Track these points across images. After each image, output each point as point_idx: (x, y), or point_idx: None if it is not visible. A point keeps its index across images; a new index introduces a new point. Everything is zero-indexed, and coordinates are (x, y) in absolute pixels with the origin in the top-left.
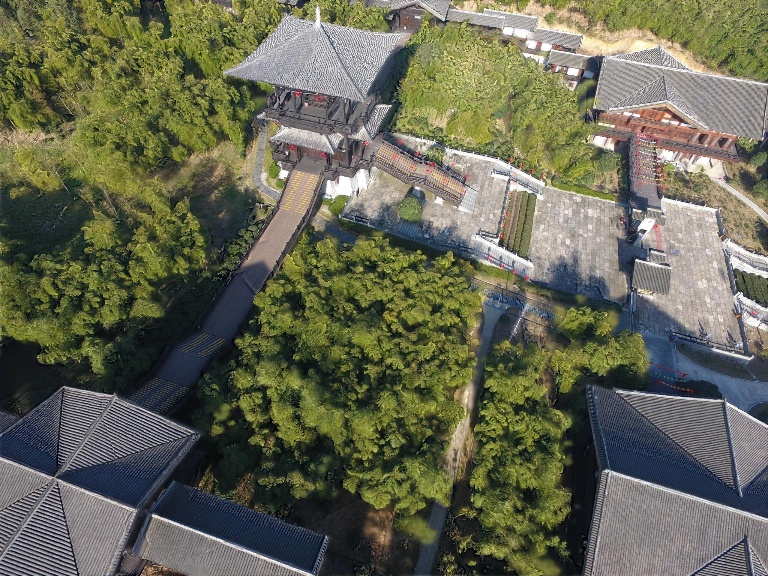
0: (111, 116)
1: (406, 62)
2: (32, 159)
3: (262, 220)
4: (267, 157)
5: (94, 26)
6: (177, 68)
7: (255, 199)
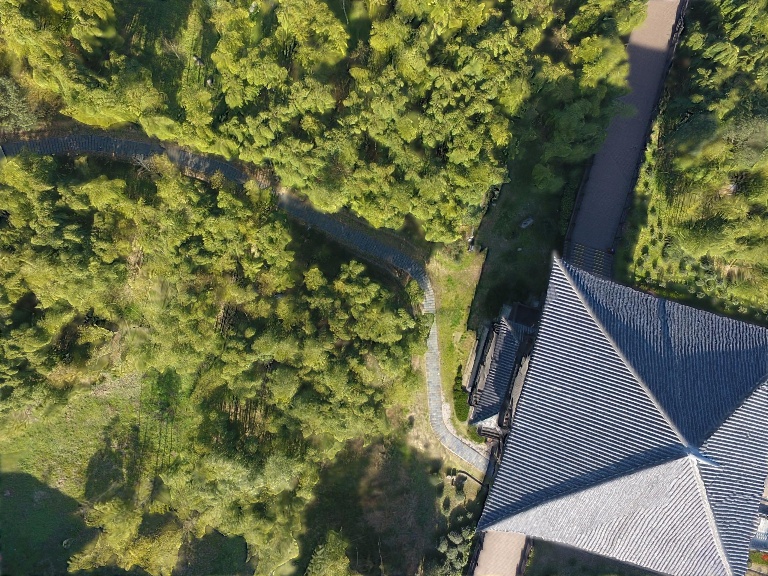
0: (215, 419)
1: (702, 150)
2: (128, 524)
3: (460, 507)
4: (444, 366)
5: (57, 91)
6: (285, 258)
7: (442, 463)
